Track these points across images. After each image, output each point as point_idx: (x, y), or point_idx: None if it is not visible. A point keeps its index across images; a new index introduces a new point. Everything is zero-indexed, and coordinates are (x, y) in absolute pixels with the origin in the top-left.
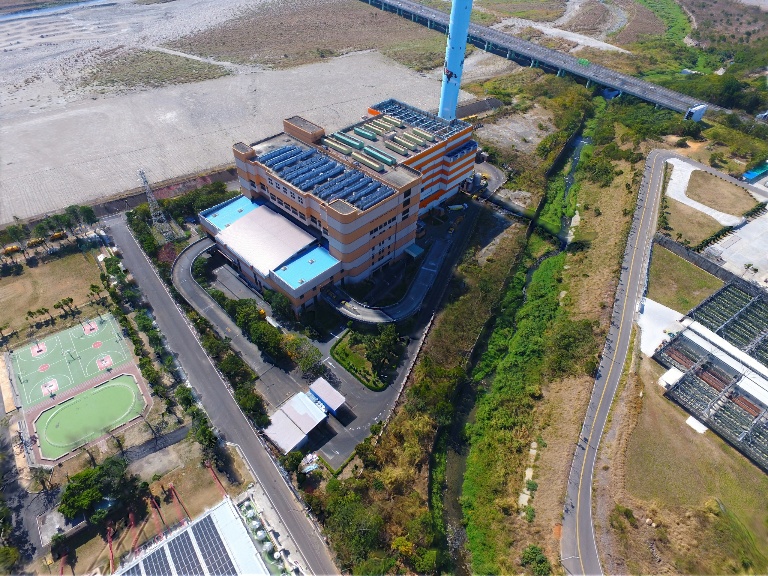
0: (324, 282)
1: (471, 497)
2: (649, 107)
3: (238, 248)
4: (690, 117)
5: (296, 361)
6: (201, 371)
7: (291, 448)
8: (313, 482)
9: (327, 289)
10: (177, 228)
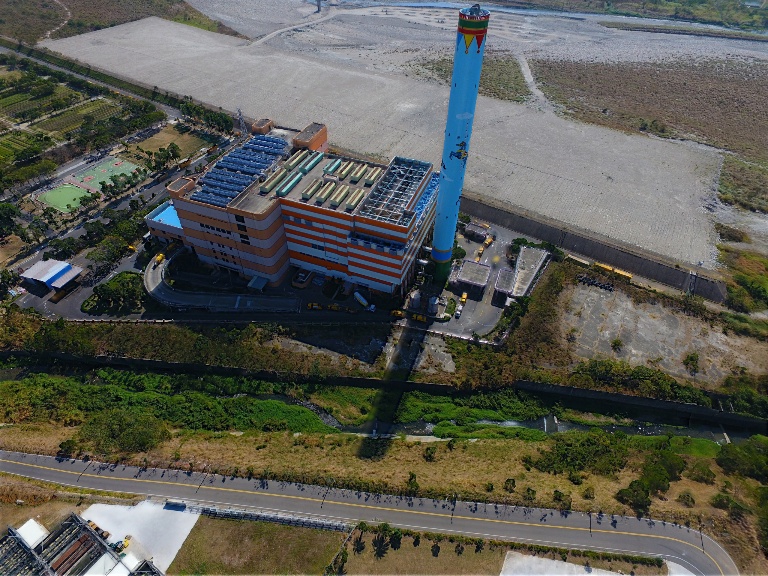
0: (173, 234)
1: None
2: None
3: None
4: None
5: None
6: None
7: (23, 276)
8: (2, 297)
9: (179, 244)
10: None
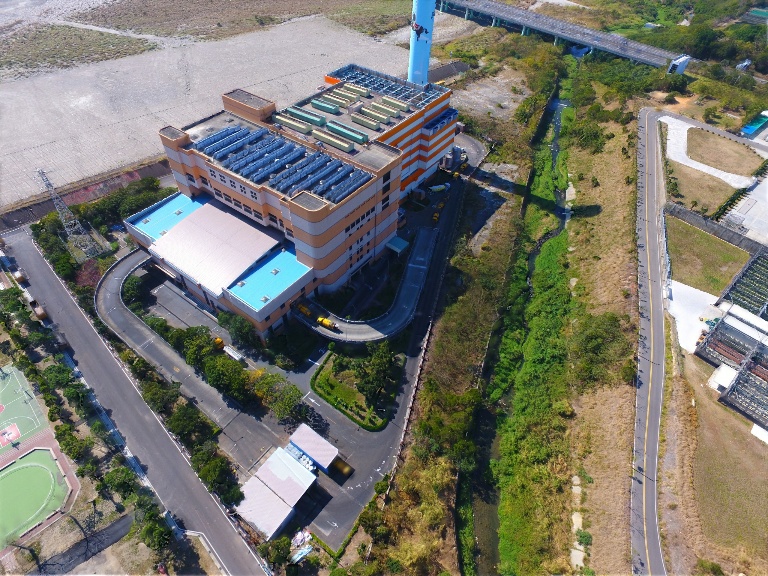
0: (294, 296)
1: (512, 563)
2: (625, 63)
3: (179, 262)
4: (674, 70)
5: (269, 406)
6: (144, 431)
7: (274, 530)
8: (308, 573)
9: (298, 304)
10: (100, 240)
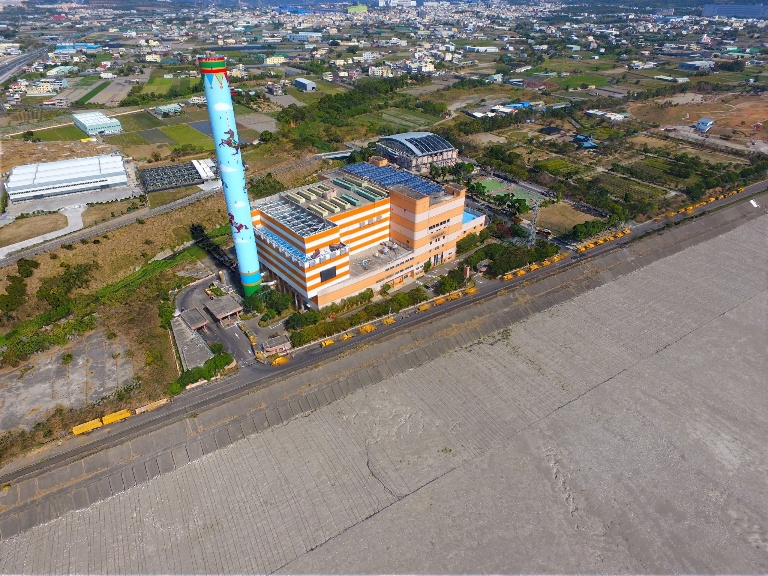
0: None
1: None
2: None
3: None
4: None
5: None
6: None
7: None
8: None
9: None
10: None
